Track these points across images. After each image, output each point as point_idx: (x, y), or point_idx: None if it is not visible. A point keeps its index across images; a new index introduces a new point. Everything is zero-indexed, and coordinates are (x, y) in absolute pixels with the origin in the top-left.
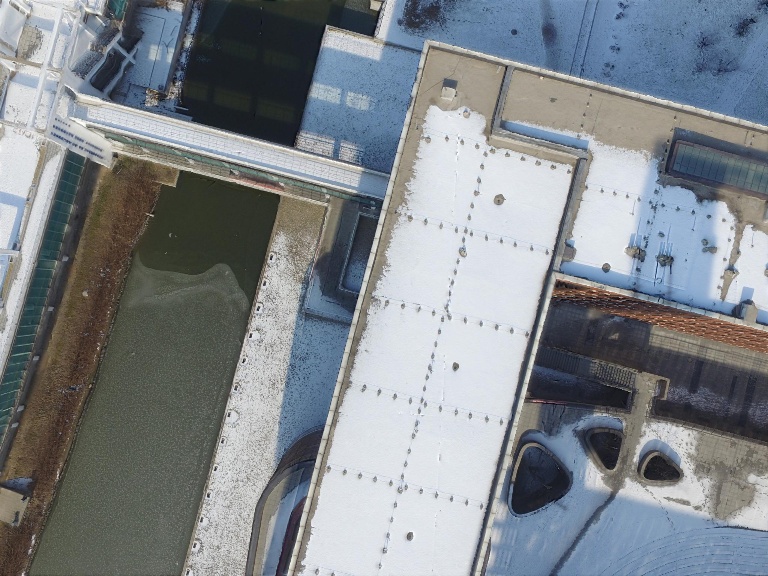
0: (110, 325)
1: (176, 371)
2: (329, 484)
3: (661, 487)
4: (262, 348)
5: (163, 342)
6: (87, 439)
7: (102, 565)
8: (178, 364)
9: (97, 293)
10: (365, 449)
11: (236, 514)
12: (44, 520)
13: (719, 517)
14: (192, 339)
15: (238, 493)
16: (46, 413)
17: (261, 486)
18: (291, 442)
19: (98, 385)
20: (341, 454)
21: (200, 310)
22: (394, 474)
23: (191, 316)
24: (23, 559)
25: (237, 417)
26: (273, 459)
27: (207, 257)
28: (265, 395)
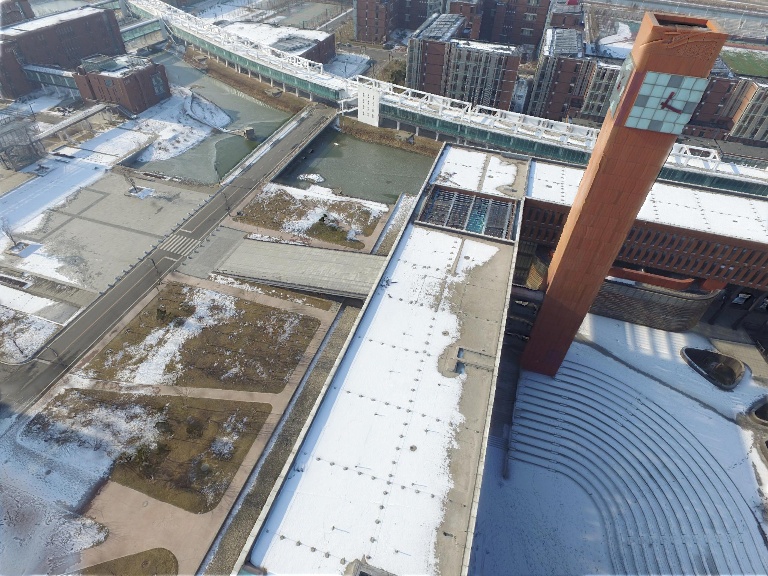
0: None
1: None
2: None
3: (761, 460)
4: None
5: None
6: None
7: None
8: None
9: None
10: None
11: None
12: None
13: (763, 514)
14: None
15: None
16: None
17: None
18: None
19: None
20: None
21: None
22: (764, 218)
23: None
24: None
25: None
26: None
27: None
28: None
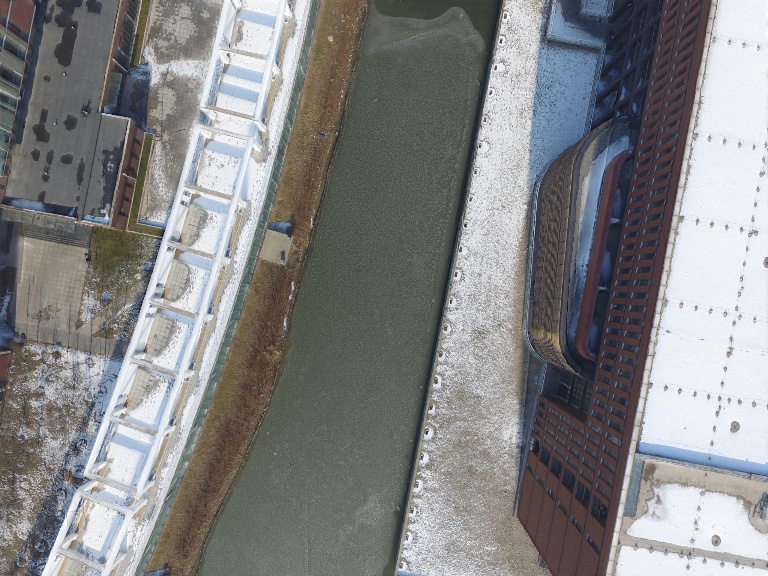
0: (352, 72)
1: (419, 114)
2: (715, 54)
3: None
4: (508, 79)
5: (404, 87)
6: (337, 185)
7: (361, 306)
8: (420, 107)
9: (340, 39)
10: (747, 19)
11: (494, 241)
12: (302, 265)
13: None
14: (432, 82)
15: (494, 221)
16: (300, 157)
17: (516, 213)
18: (542, 168)
19: (344, 132)
20: (725, 25)
21: (438, 53)
22: None
23: (430, 60)
24: (285, 304)
25: (488, 148)
26: (526, 186)
27: (441, 1)
28: (514, 124)
